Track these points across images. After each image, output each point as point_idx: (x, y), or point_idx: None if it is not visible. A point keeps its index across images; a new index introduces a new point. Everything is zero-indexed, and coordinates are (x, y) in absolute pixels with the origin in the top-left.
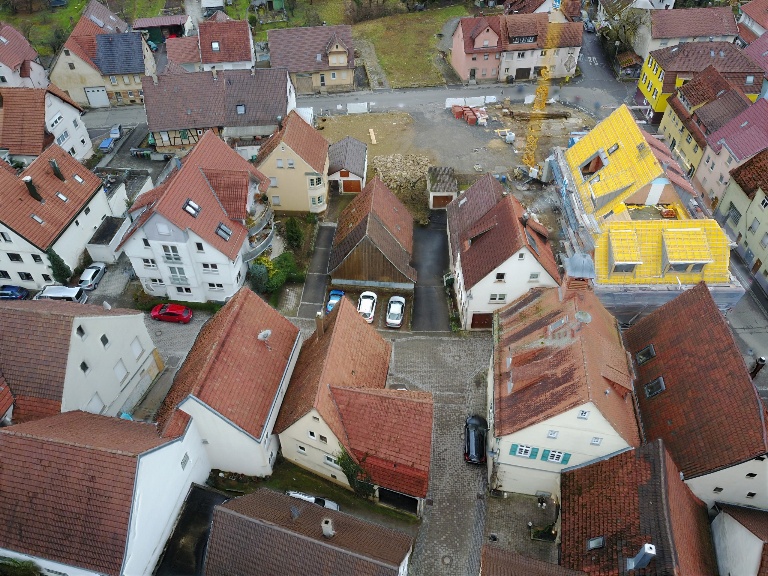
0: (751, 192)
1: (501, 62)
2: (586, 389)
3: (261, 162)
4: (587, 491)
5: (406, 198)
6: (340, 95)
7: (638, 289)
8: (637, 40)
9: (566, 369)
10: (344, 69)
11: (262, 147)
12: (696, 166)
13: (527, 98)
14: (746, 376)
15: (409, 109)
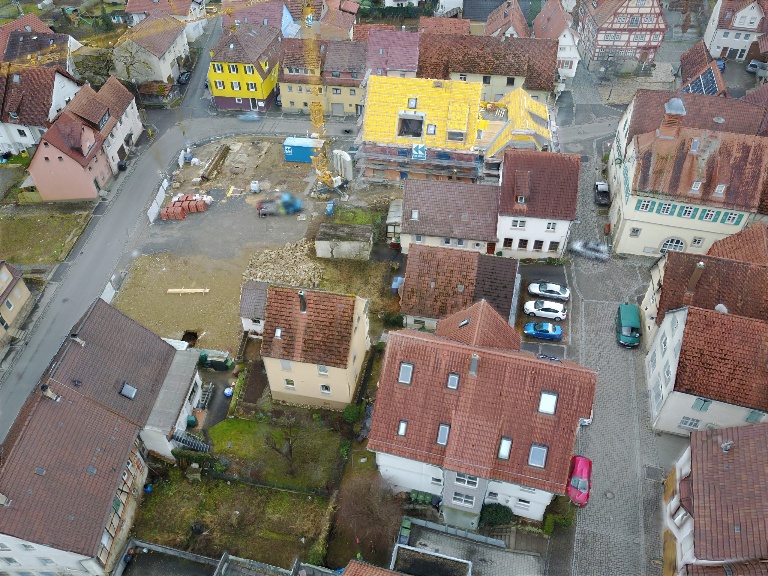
0: None
1: (107, 154)
2: (766, 139)
3: (348, 344)
4: (764, 195)
5: None
6: (39, 317)
7: (557, 147)
8: (150, 67)
9: (739, 149)
10: (15, 285)
11: (285, 353)
12: None
13: (180, 161)
14: (718, 97)
15: (132, 253)
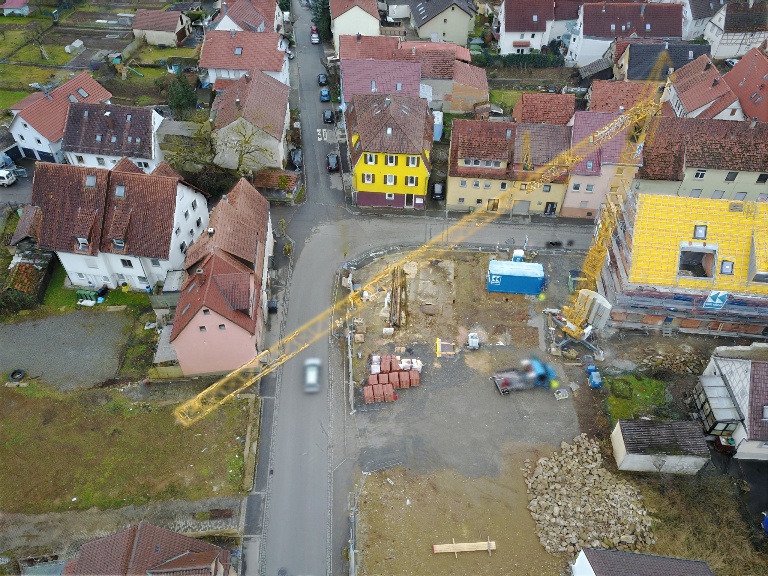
0: (678, 176)
1: (262, 300)
2: None
3: None
4: None
5: (679, 505)
6: None
7: None
8: None
9: None
10: None
11: None
12: (560, 200)
13: None
14: None
15: (347, 470)
